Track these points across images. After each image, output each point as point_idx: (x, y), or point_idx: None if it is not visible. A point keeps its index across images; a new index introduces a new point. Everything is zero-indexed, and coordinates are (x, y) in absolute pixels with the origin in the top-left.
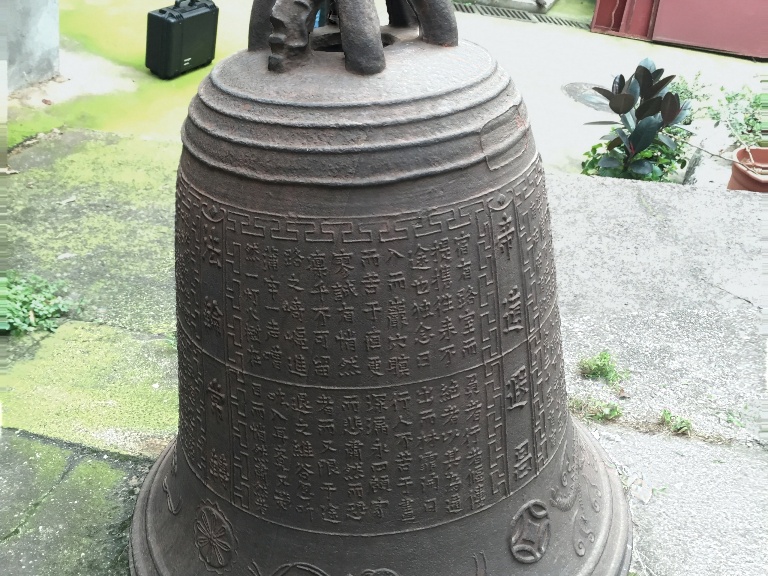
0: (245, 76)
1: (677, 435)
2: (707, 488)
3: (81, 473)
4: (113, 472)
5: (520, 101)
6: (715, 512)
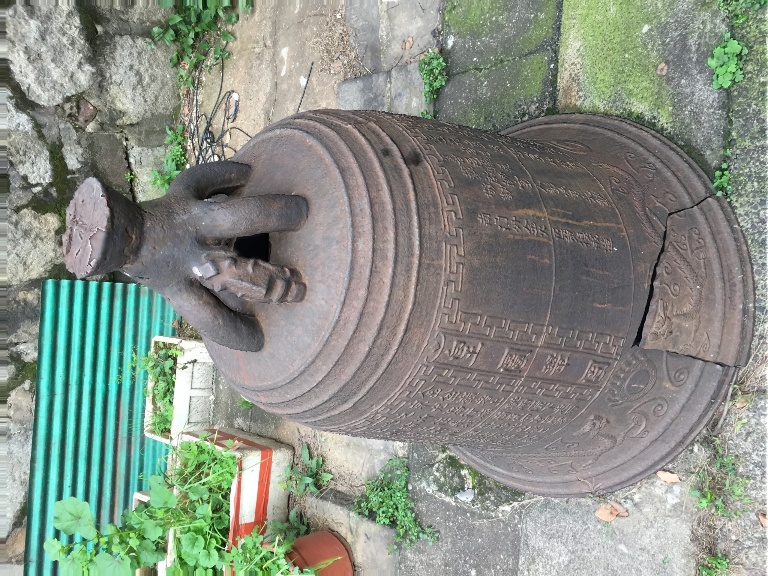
0: (213, 197)
1: (696, 565)
2: (625, 573)
3: (533, 64)
4: (539, 85)
5: (276, 413)
6: (598, 571)
